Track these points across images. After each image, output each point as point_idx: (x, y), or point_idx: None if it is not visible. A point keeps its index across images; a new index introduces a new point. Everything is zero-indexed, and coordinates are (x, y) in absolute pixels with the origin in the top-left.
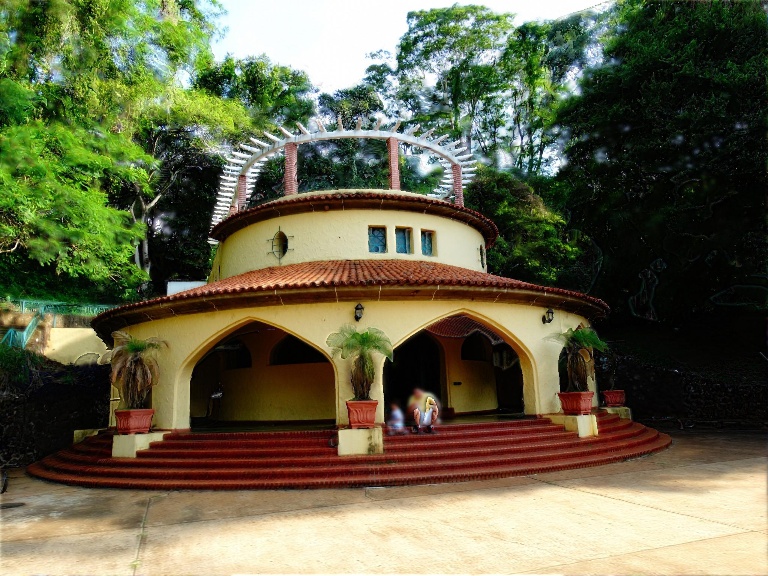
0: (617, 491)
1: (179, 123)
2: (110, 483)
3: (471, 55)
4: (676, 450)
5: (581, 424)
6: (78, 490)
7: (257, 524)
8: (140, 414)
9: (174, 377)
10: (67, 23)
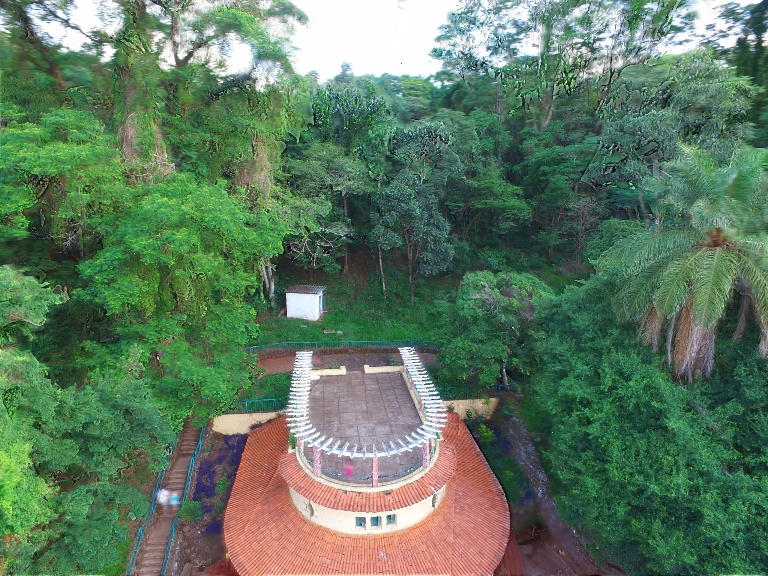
0: None
1: None
2: None
3: (564, 1)
4: None
5: None
6: None
7: None
8: None
9: None
10: None
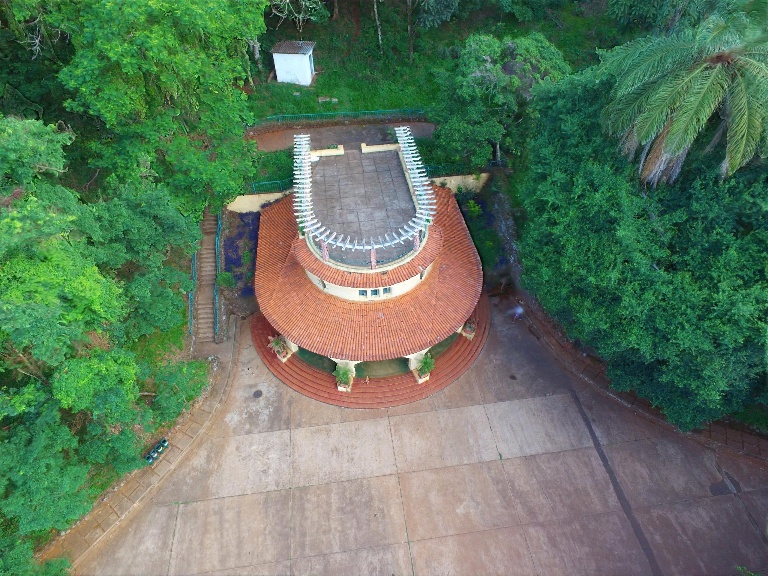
0: (397, 434)
1: None
2: (280, 379)
3: None
4: (458, 383)
5: (420, 381)
6: (272, 379)
7: (312, 435)
8: None
9: None
10: (175, 89)
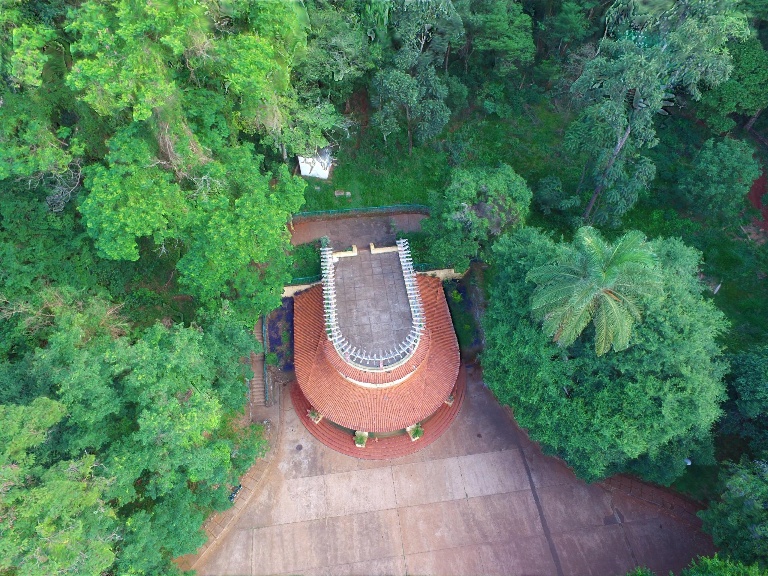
0: (397, 479)
1: (291, 153)
2: (314, 436)
3: None
4: (440, 440)
5: None
6: (309, 435)
7: None
8: None
9: None
10: None
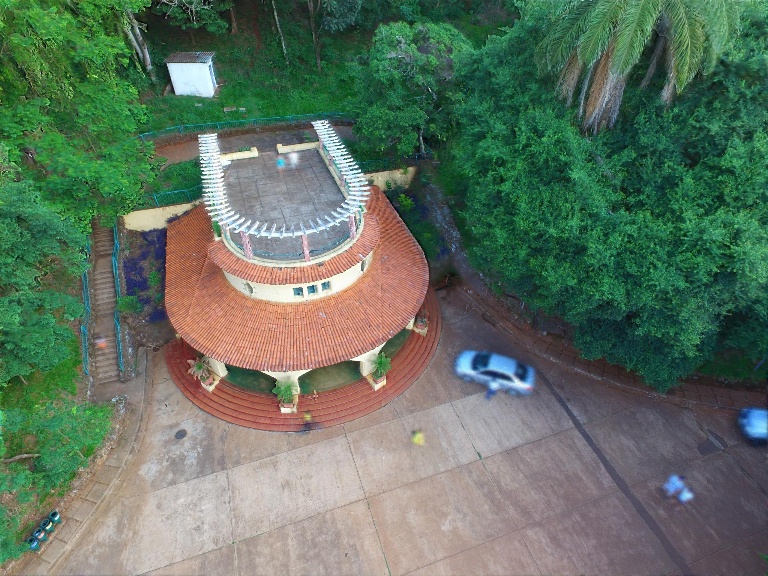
0: (359, 452)
1: None
2: None
3: None
4: (418, 384)
5: None
6: (198, 413)
7: (255, 472)
8: (208, 380)
9: (216, 364)
10: (37, 65)
